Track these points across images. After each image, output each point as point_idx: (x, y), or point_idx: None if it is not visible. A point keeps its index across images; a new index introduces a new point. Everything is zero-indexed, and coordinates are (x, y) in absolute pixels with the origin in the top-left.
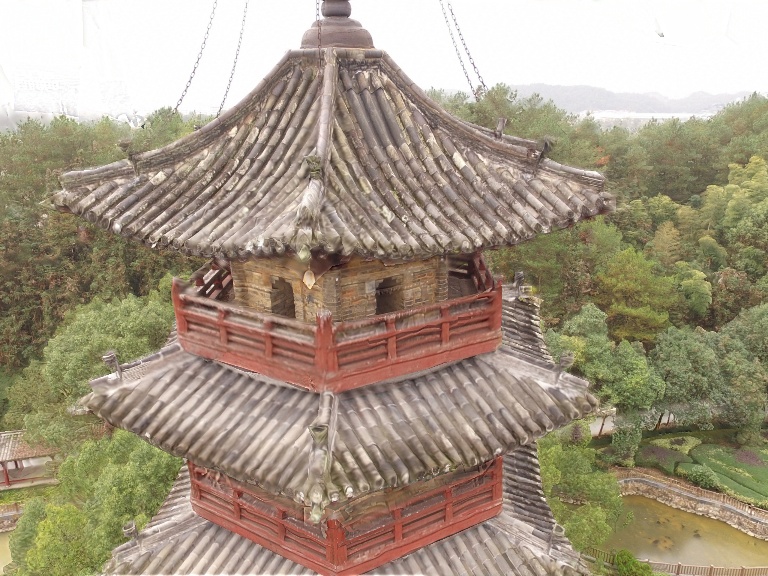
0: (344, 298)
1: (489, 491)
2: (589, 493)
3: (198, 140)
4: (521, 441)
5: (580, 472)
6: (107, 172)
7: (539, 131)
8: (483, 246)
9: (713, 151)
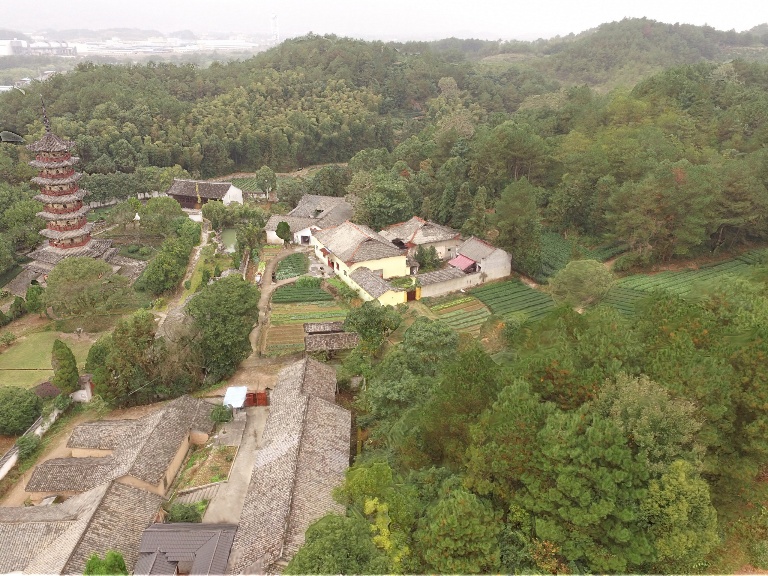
0: None
1: None
2: None
3: None
4: None
5: None
6: None
7: None
8: None
9: (9, 117)
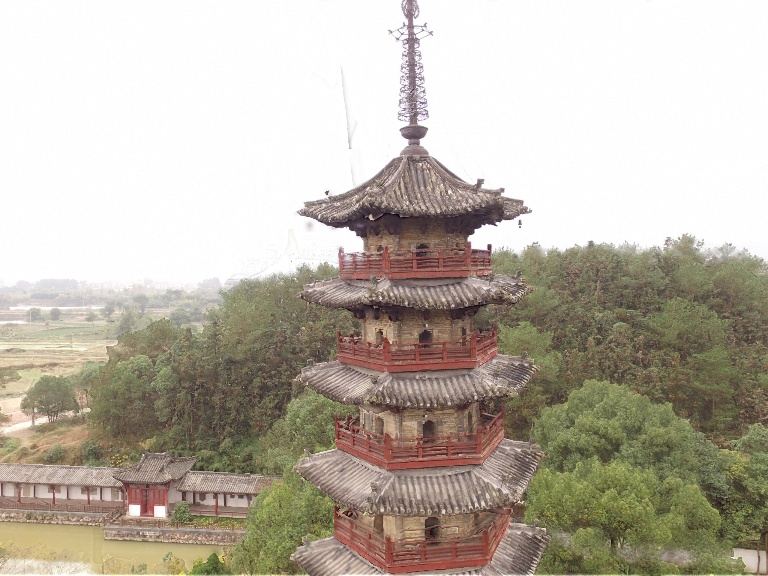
0: (402, 249)
1: (469, 352)
2: (713, 571)
3: (354, 191)
4: (465, 303)
5: (706, 551)
6: (320, 202)
7: (725, 274)
8: (441, 213)
9: None
